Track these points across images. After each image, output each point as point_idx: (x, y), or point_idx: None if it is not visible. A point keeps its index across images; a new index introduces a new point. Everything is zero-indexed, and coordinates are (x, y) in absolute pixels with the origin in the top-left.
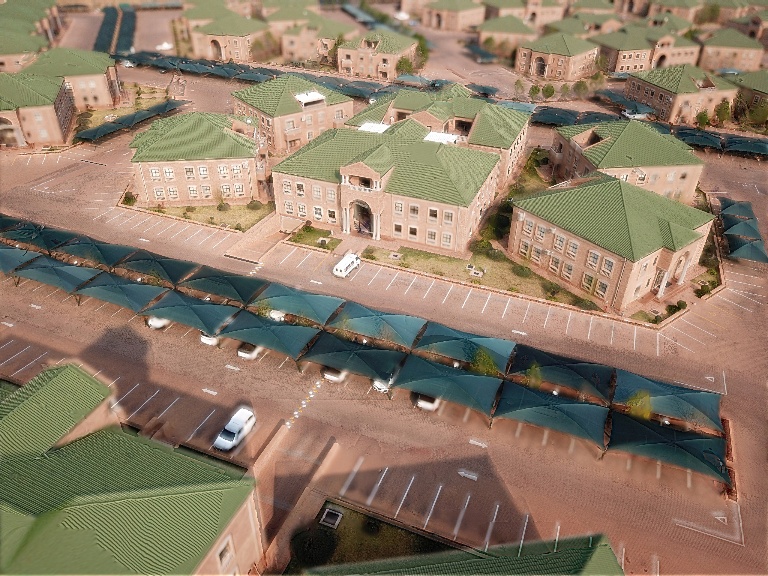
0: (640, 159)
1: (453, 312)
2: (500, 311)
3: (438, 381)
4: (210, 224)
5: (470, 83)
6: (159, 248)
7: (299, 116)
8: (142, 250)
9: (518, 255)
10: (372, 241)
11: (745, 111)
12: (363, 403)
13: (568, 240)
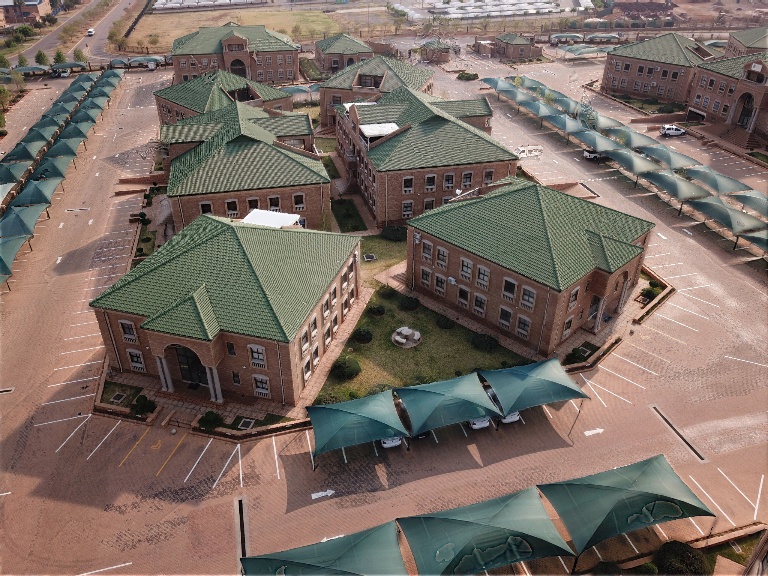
0: None
1: None
2: None
3: None
4: None
5: None
6: None
7: None
8: (680, 191)
9: None
10: None
11: None
12: None
13: None
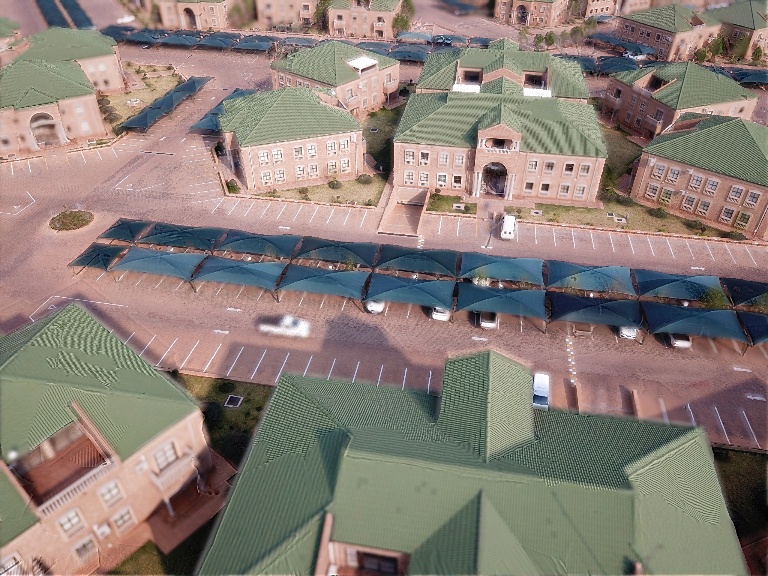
0: (708, 97)
1: (629, 258)
2: (668, 251)
3: (692, 320)
4: (339, 203)
5: (464, 36)
6: (307, 234)
7: (356, 83)
8: (312, 237)
9: (643, 198)
10: (505, 201)
11: (726, 45)
12: (621, 351)
13: (708, 179)
